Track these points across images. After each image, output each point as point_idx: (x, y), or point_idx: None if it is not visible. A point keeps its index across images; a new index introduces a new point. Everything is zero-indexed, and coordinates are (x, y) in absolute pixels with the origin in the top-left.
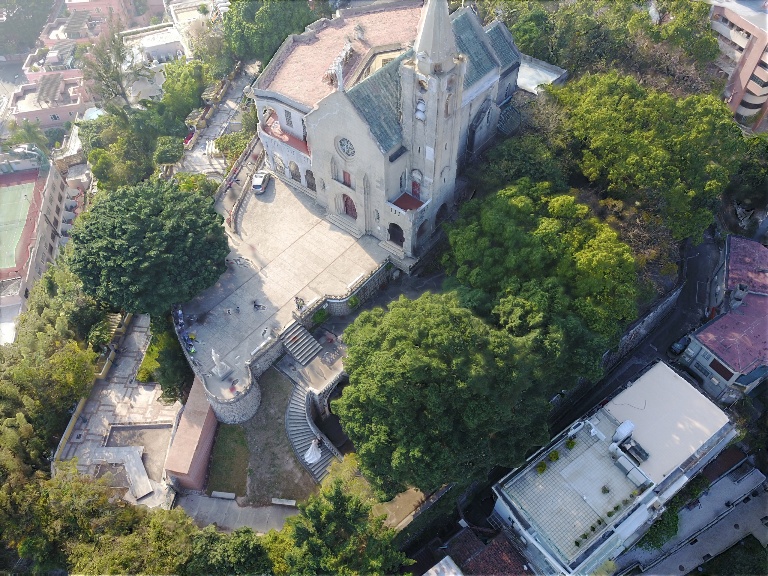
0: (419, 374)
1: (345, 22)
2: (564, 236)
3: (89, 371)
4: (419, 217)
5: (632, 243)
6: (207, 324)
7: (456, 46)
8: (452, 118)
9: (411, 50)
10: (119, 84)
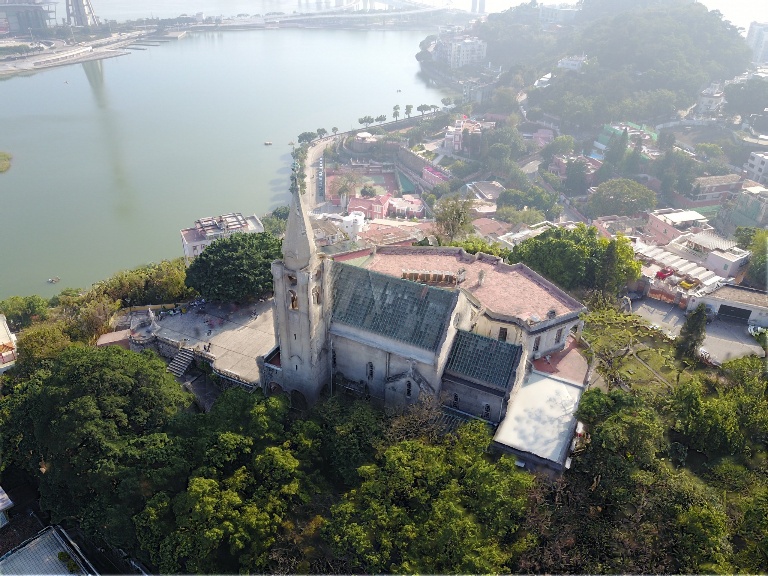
0: (57, 362)
1: (510, 272)
2: (239, 469)
3: (172, 288)
4: (268, 372)
5: (276, 571)
6: (196, 315)
7: (417, 305)
8: (299, 316)
9: (377, 273)
10: (453, 229)
